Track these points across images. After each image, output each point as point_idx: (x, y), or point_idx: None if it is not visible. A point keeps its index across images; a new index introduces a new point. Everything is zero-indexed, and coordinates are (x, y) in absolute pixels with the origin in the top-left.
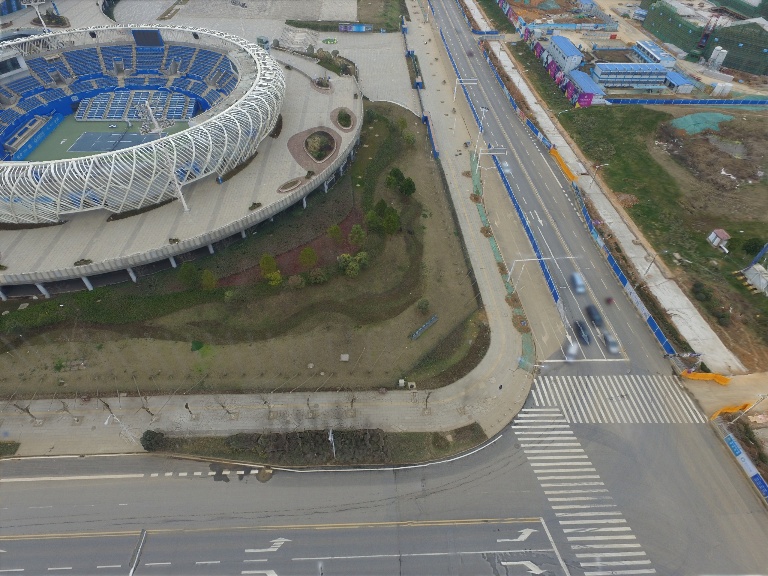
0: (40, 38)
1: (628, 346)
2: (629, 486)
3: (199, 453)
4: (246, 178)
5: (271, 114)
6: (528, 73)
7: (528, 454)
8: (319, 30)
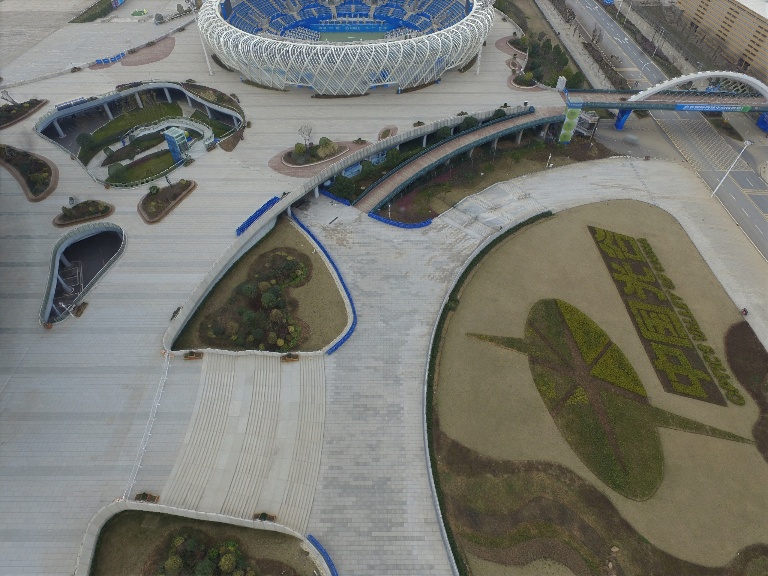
0: None
1: None
2: None
3: None
4: None
5: None
6: None
7: None
8: (102, 16)
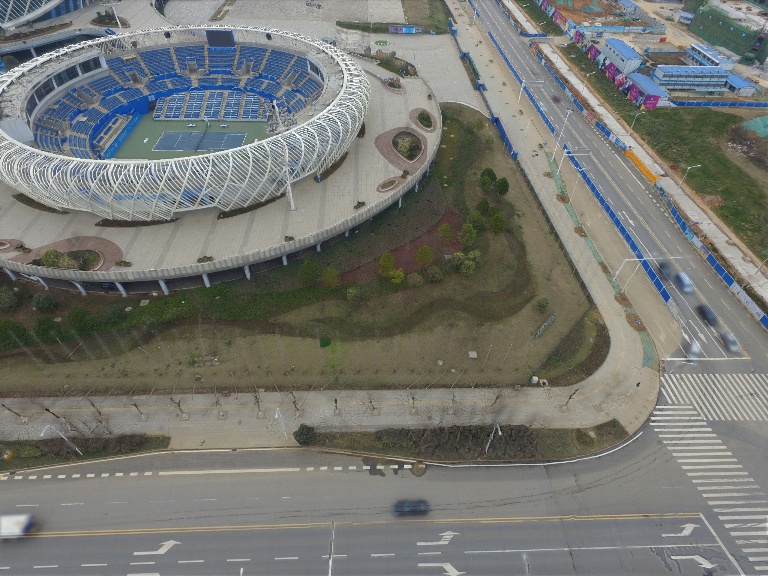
0: (119, 38)
1: (747, 345)
2: None
3: (350, 448)
4: (343, 177)
5: (364, 114)
6: (585, 75)
7: (672, 450)
8: (369, 32)
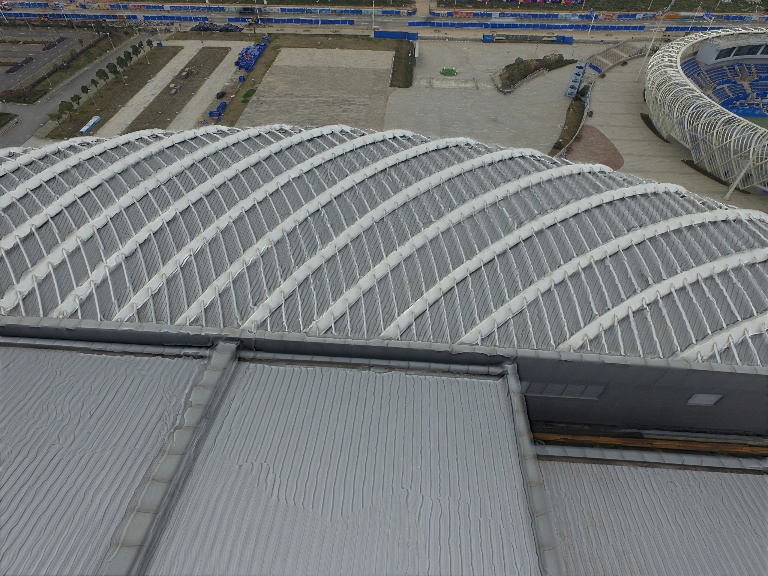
0: None
1: None
2: None
3: None
4: None
5: None
6: (516, 9)
7: None
8: None
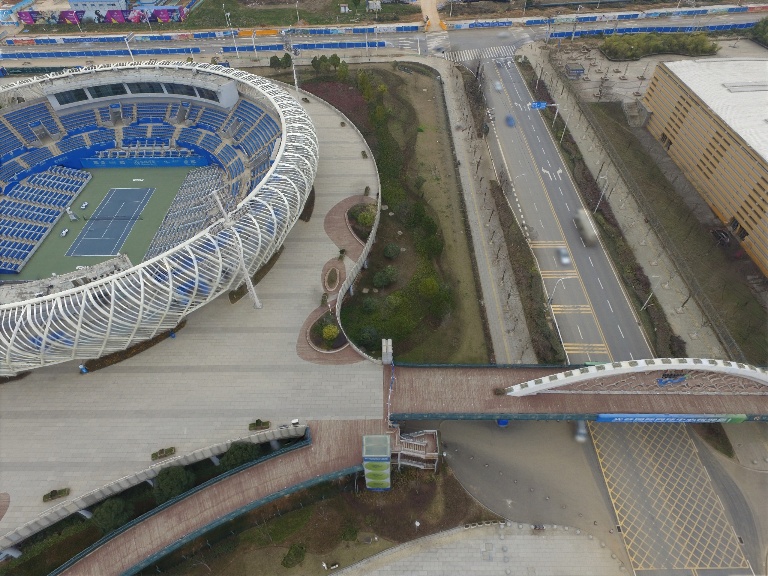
0: None
1: None
2: None
3: None
4: None
5: None
6: (102, 31)
7: None
8: None
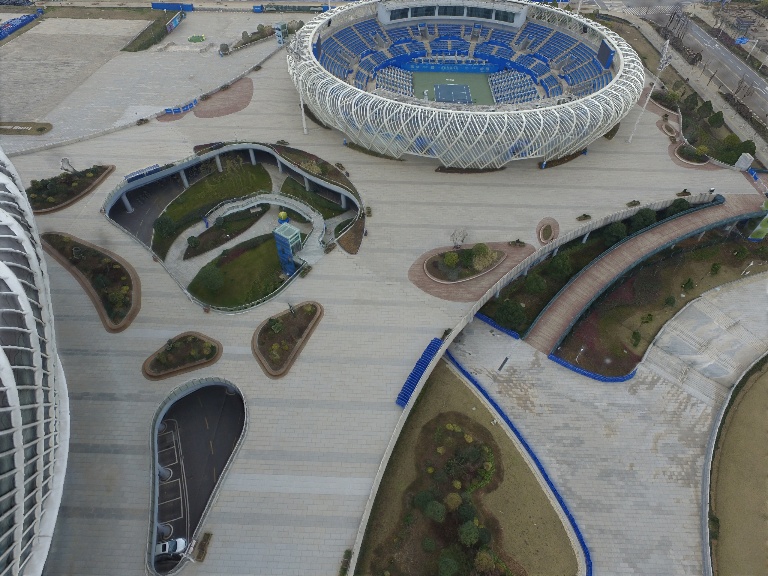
0: None
1: None
2: (646, 4)
3: None
4: None
5: None
6: None
7: None
8: (157, 42)
